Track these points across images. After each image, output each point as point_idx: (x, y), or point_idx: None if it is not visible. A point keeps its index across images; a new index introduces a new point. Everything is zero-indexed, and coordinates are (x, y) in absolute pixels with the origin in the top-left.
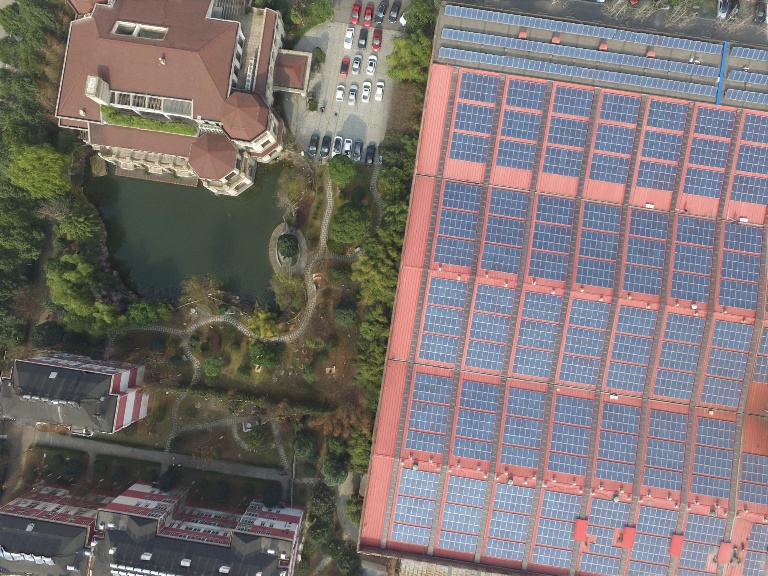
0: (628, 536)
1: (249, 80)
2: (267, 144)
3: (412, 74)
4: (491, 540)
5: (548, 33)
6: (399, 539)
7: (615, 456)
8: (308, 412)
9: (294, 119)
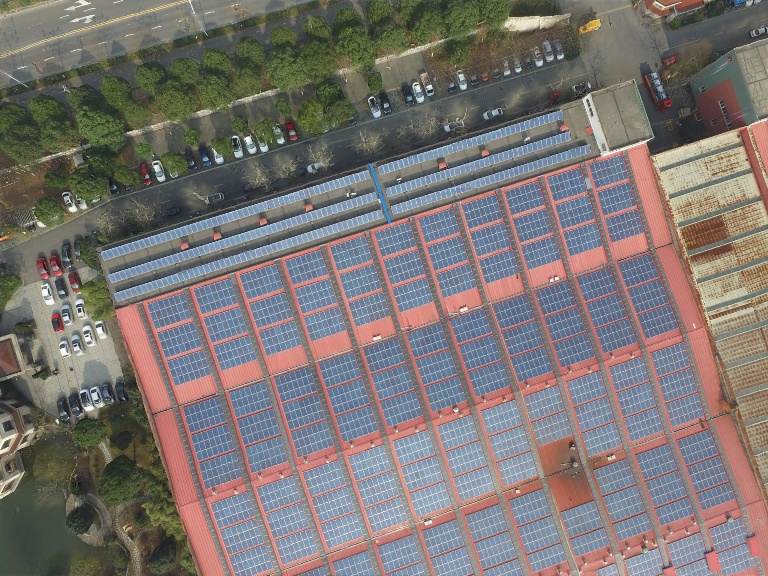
0: None
1: None
2: (10, 441)
3: None
4: None
5: (209, 231)
6: None
7: (453, 575)
8: None
9: (33, 394)
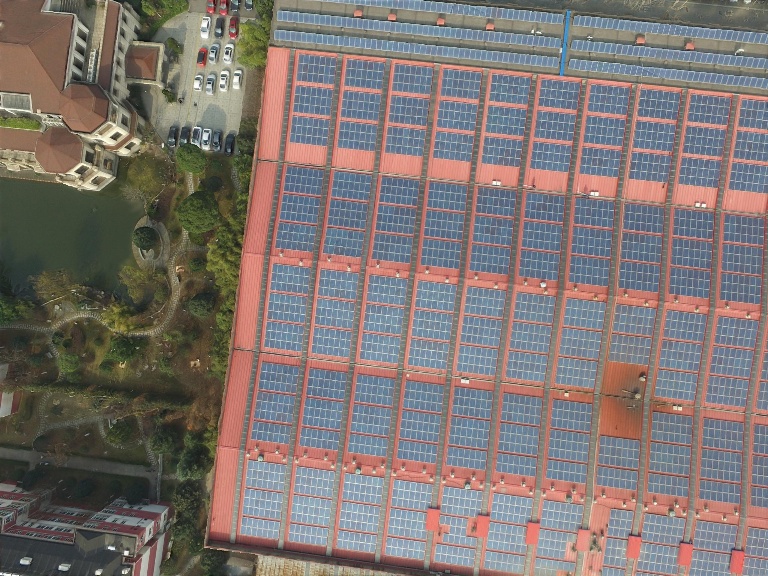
0: (482, 525)
1: (90, 72)
2: (120, 136)
3: (258, 59)
4: (342, 532)
5: (386, 11)
6: (248, 533)
7: (467, 442)
8: (167, 406)
9: (154, 111)
